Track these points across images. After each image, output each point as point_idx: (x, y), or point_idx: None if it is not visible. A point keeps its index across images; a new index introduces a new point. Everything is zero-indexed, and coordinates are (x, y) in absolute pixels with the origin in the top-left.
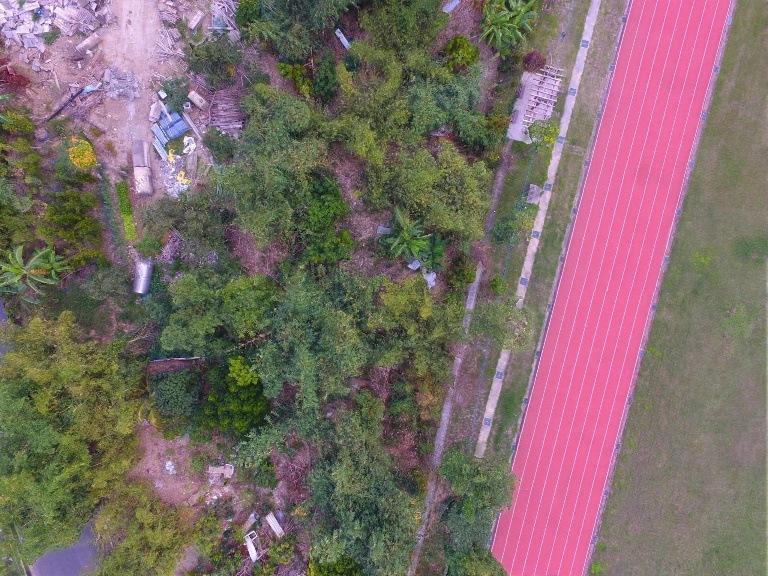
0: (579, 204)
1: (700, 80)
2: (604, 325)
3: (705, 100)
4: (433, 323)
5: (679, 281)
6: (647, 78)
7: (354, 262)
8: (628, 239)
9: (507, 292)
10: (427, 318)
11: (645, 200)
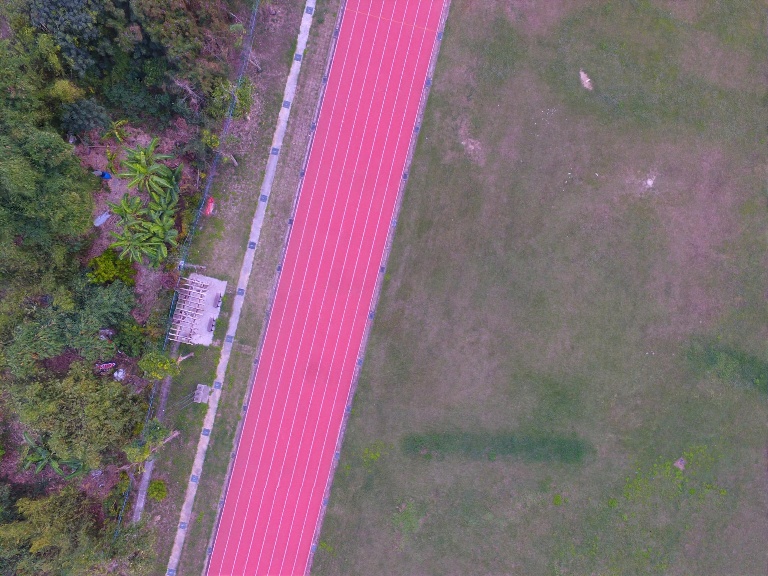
0: (249, 402)
1: (367, 280)
2: (276, 521)
3: (372, 299)
4: (58, 548)
5: (349, 477)
6: (314, 278)
7: (21, 463)
8: (298, 436)
9: (177, 490)
10: (47, 546)
11: (314, 397)
